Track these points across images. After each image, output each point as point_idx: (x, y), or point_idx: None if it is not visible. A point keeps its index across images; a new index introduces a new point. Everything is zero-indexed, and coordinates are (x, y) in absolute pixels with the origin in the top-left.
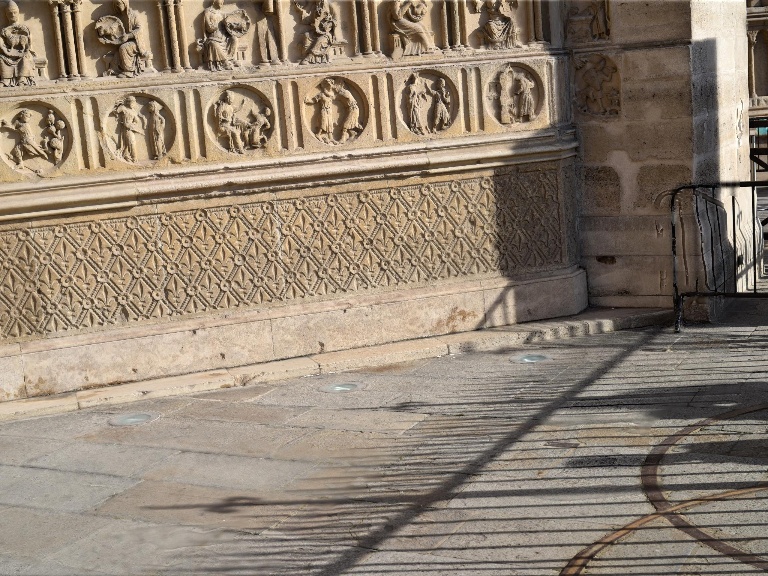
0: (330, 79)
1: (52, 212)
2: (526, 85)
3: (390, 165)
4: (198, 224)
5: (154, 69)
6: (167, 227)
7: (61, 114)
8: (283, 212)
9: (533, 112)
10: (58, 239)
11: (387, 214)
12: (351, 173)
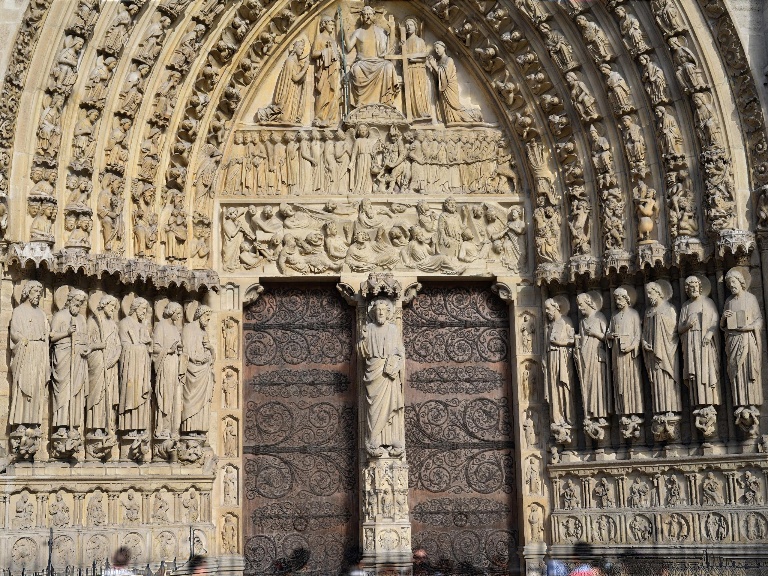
0: (675, 514)
1: (575, 557)
2: (760, 522)
3: (696, 553)
4: (624, 568)
5: (615, 506)
6: (613, 568)
7: (580, 521)
8: (655, 568)
9: (765, 535)
10: (577, 567)
11: (697, 574)
12: (681, 554)
